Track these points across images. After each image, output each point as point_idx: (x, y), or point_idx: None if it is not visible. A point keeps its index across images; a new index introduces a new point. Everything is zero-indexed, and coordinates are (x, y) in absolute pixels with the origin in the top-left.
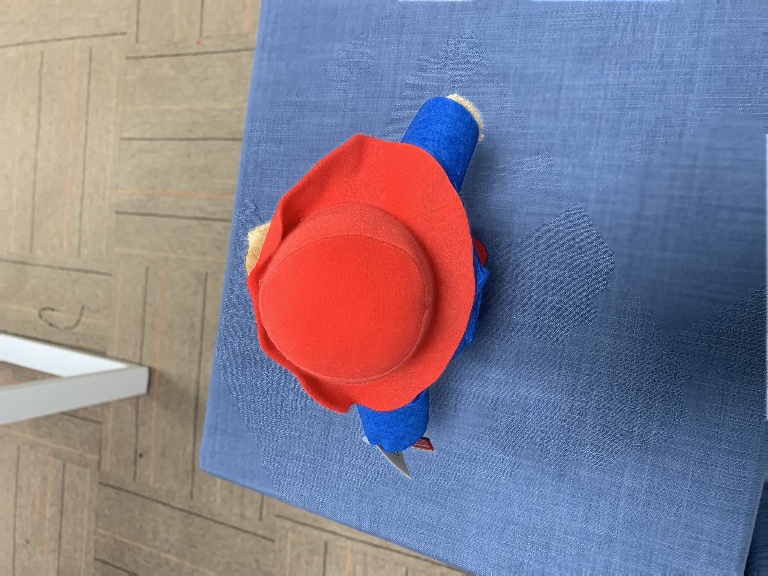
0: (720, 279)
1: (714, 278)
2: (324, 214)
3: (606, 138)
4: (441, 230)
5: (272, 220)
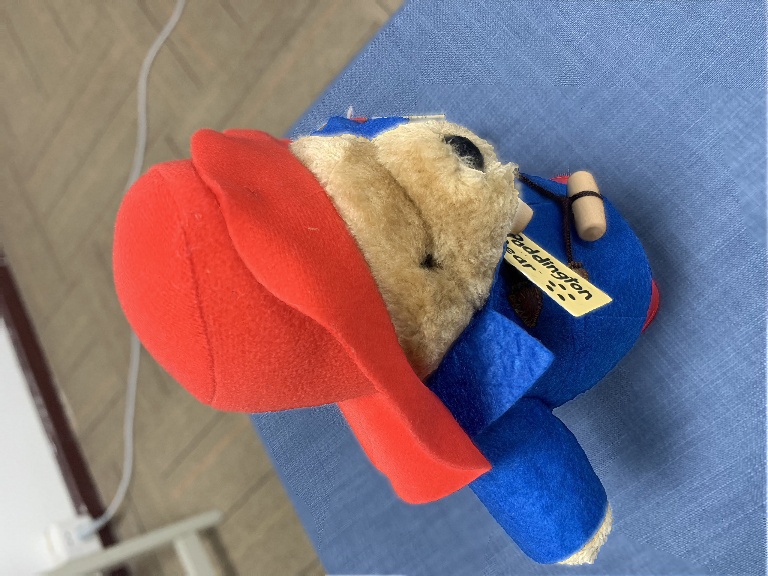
0: (351, 507)
1: (355, 505)
2: (321, 351)
3: (533, 571)
4: (352, 417)
5: (311, 286)
